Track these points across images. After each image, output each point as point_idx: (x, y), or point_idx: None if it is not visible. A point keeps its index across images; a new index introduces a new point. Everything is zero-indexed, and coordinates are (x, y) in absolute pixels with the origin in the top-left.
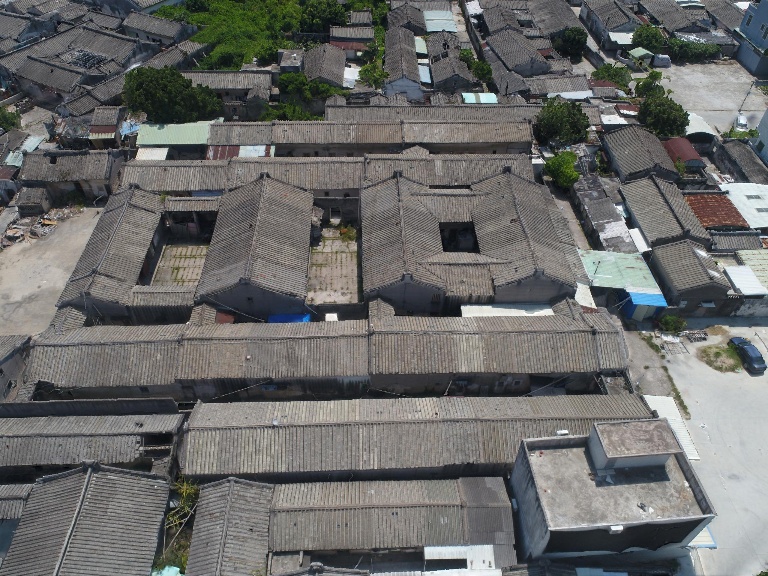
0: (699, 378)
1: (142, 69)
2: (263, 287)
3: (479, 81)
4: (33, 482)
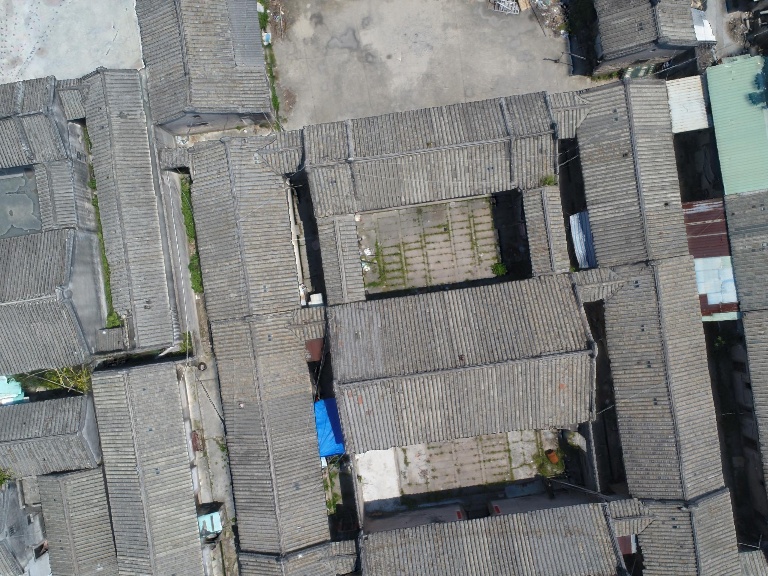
0: None
1: None
2: (339, 406)
3: None
4: None
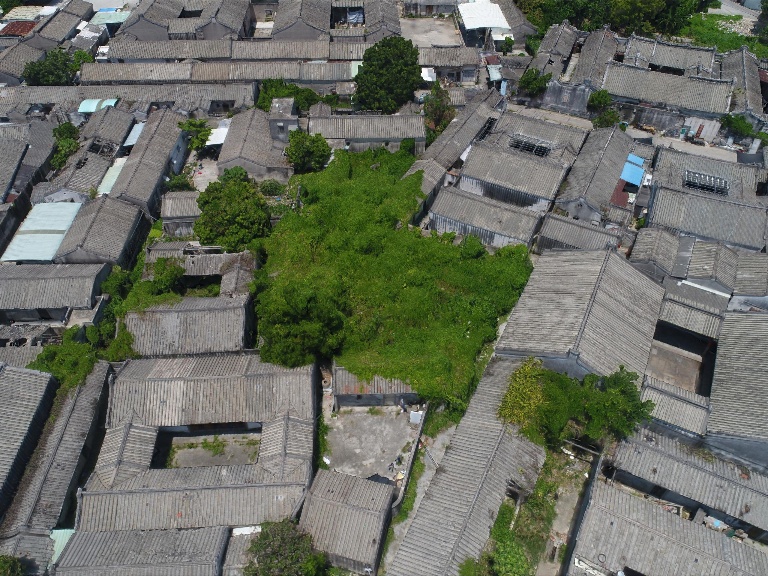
0: None
1: (407, 41)
2: None
3: (80, 126)
4: None
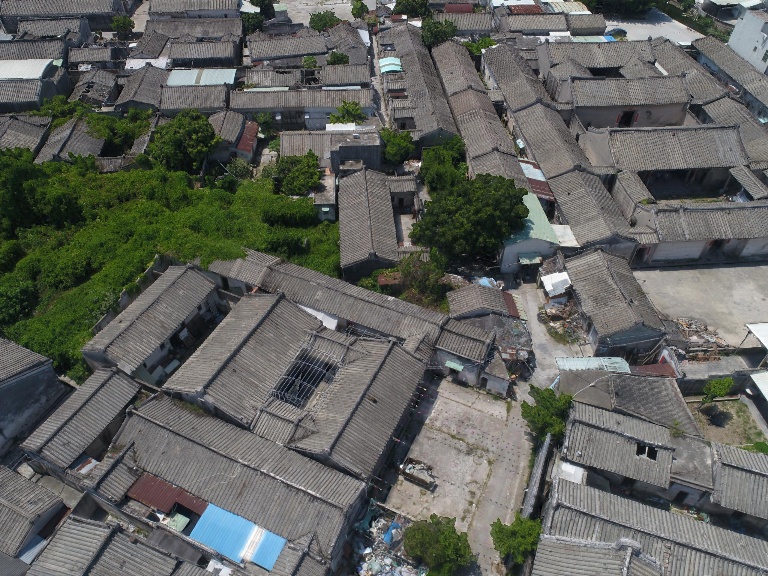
0: None
1: (495, 194)
2: None
3: None
4: None
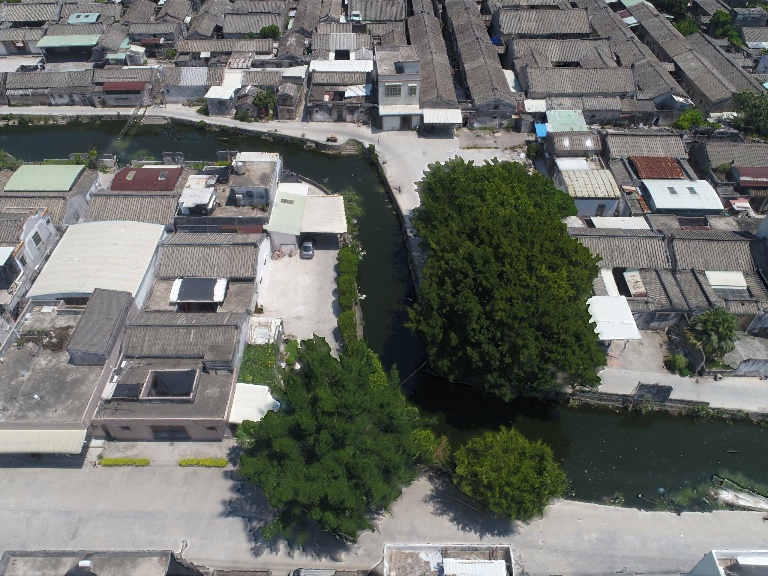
0: (492, 158)
1: None
2: (499, 16)
3: None
4: (412, 15)
